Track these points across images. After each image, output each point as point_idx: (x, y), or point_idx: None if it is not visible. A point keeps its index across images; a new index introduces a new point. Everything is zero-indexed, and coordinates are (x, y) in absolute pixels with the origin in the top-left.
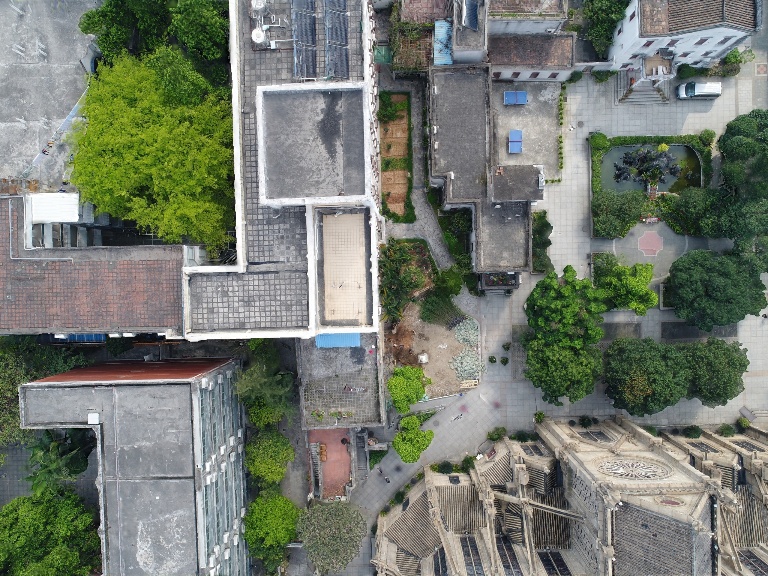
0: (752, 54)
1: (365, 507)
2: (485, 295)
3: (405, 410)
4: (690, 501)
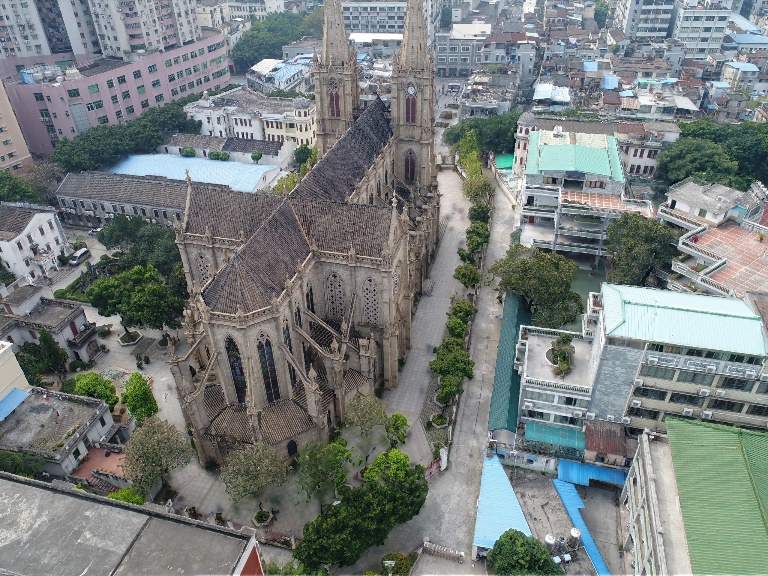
0: (80, 235)
1: (189, 477)
2: (96, 363)
3: (112, 396)
4: None
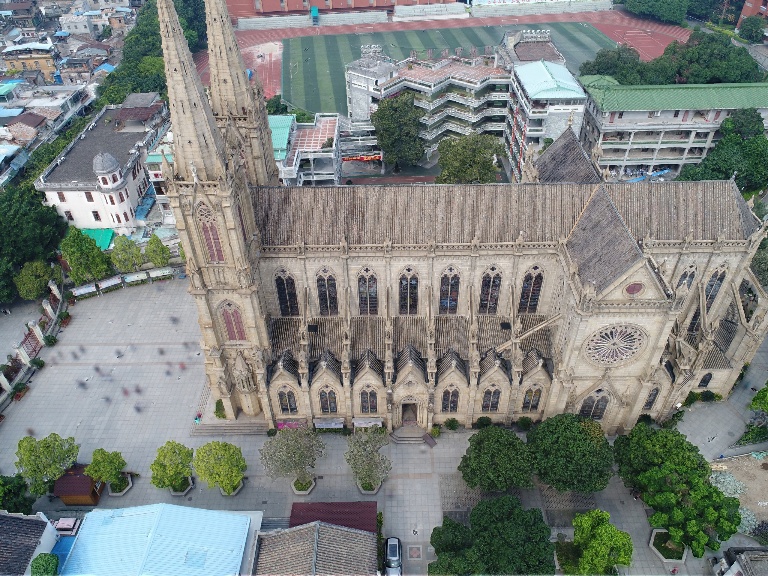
0: None
1: (764, 371)
2: None
3: None
4: (620, 289)
